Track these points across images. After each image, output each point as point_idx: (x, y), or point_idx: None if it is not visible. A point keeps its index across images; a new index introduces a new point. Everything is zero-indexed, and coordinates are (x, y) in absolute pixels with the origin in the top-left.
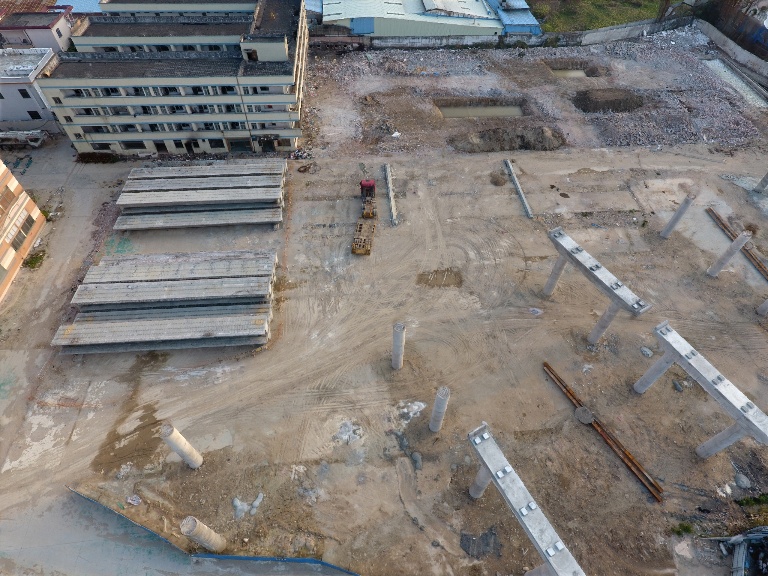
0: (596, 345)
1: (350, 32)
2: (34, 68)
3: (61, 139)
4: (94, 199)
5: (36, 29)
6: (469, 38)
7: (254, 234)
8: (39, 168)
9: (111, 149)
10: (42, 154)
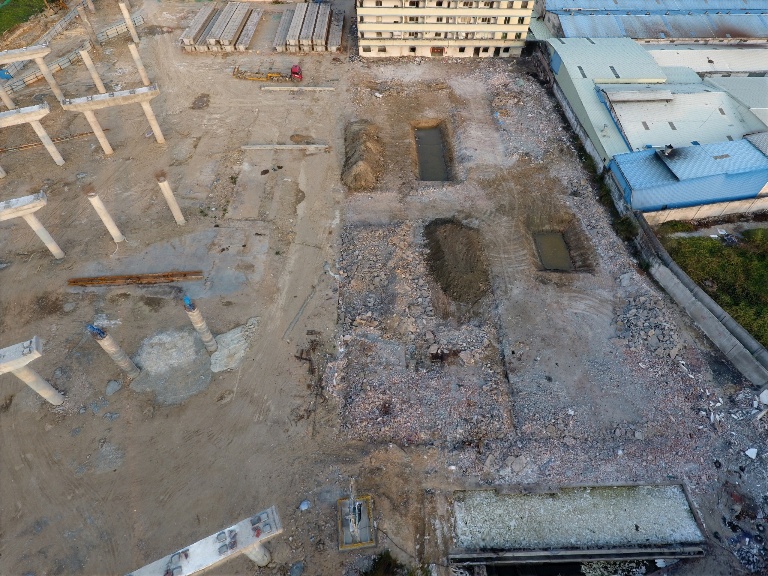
0: (104, 153)
1: None
2: None
3: None
4: None
5: None
6: None
7: None
8: None
9: None
10: None
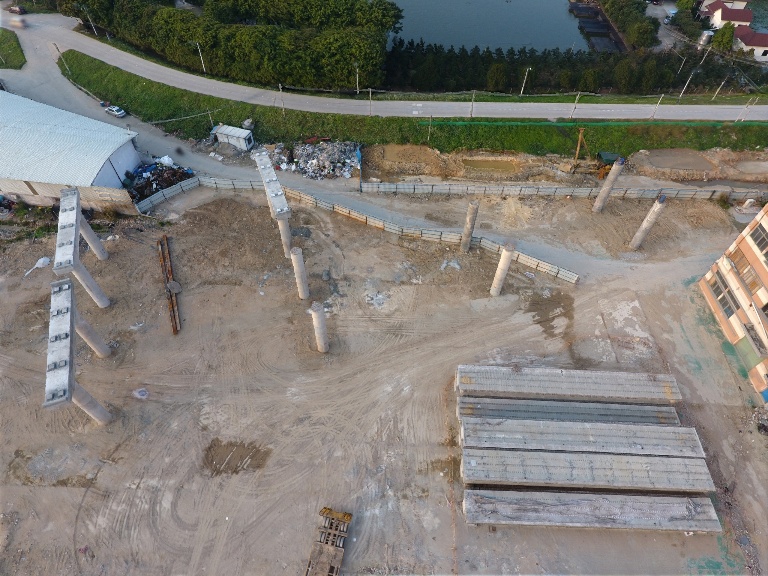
0: None
1: None
2: None
3: None
4: None
5: None
6: None
7: None
8: None
9: None
10: None
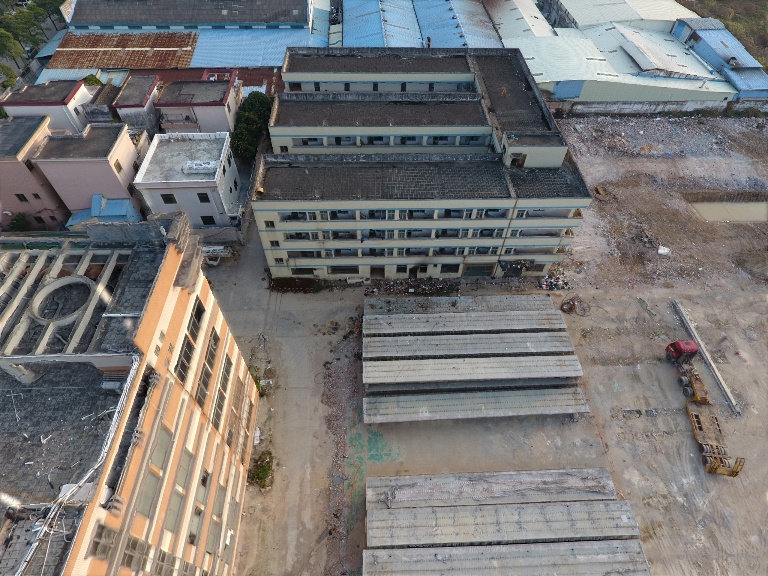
0: None
1: (551, 96)
2: (218, 166)
3: (240, 251)
4: (310, 356)
5: (207, 106)
6: (691, 104)
7: (549, 427)
8: (225, 300)
9: (314, 274)
10: (222, 276)
